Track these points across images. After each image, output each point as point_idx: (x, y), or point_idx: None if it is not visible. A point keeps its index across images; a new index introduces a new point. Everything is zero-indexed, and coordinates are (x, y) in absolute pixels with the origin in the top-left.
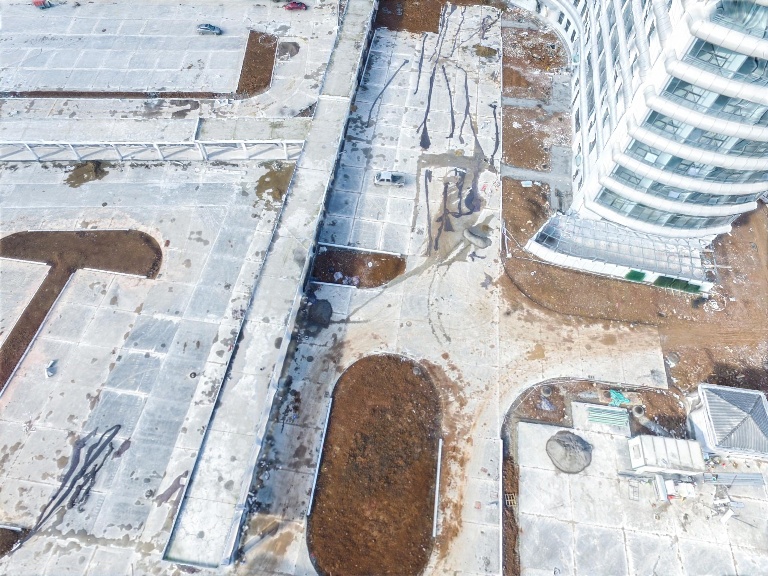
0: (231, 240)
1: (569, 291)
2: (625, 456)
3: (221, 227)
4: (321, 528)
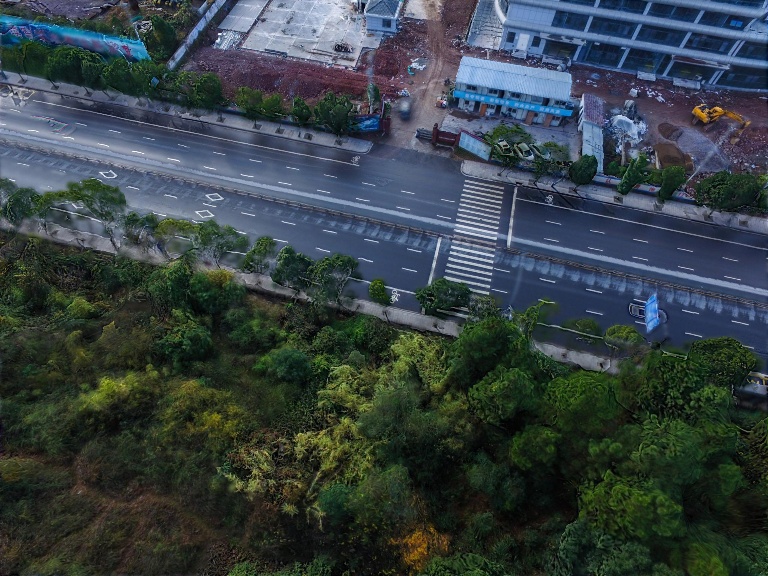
0: None
1: None
2: None
3: None
4: None
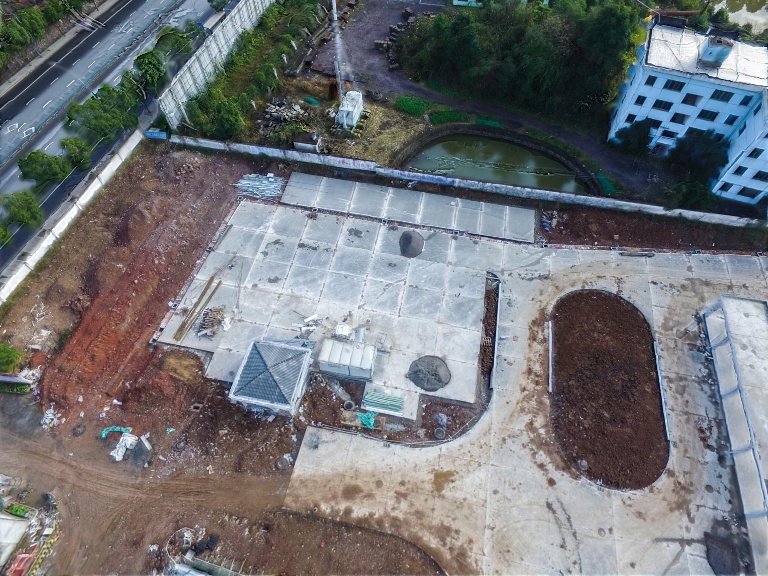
0: None
1: (383, 574)
2: (378, 366)
3: None
4: (642, 331)
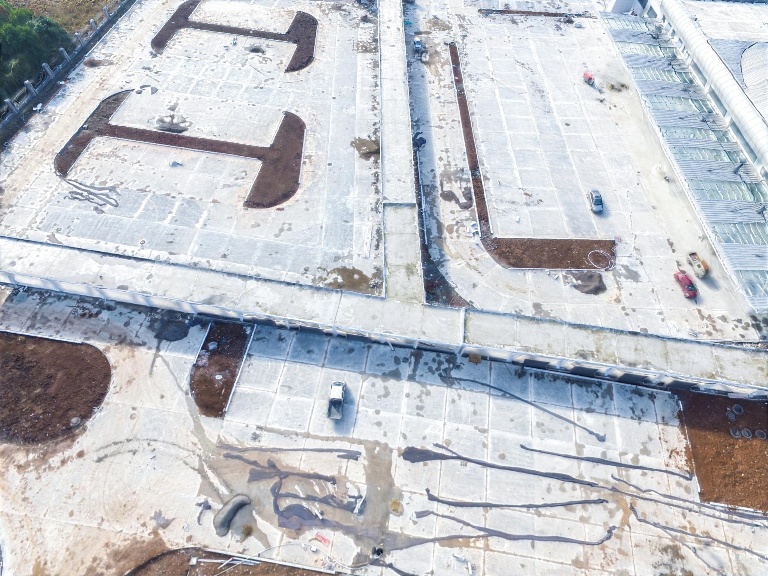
0: (278, 253)
1: None
2: None
3: (295, 244)
4: None
